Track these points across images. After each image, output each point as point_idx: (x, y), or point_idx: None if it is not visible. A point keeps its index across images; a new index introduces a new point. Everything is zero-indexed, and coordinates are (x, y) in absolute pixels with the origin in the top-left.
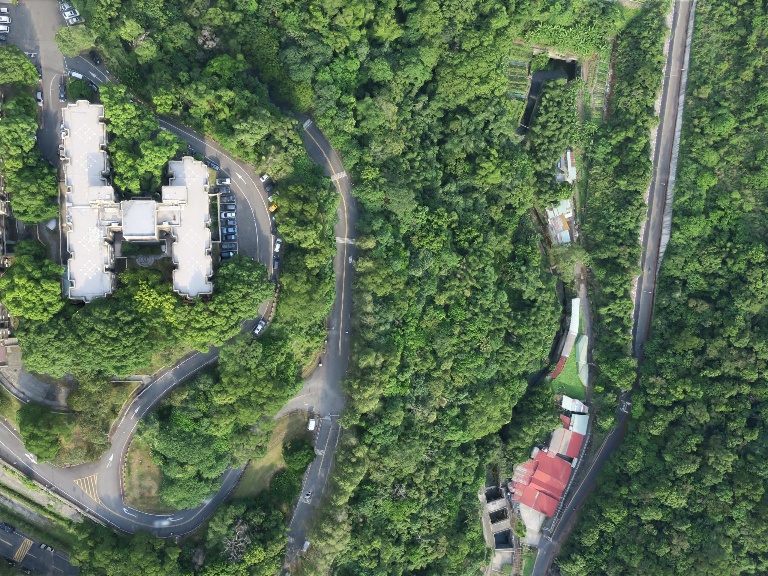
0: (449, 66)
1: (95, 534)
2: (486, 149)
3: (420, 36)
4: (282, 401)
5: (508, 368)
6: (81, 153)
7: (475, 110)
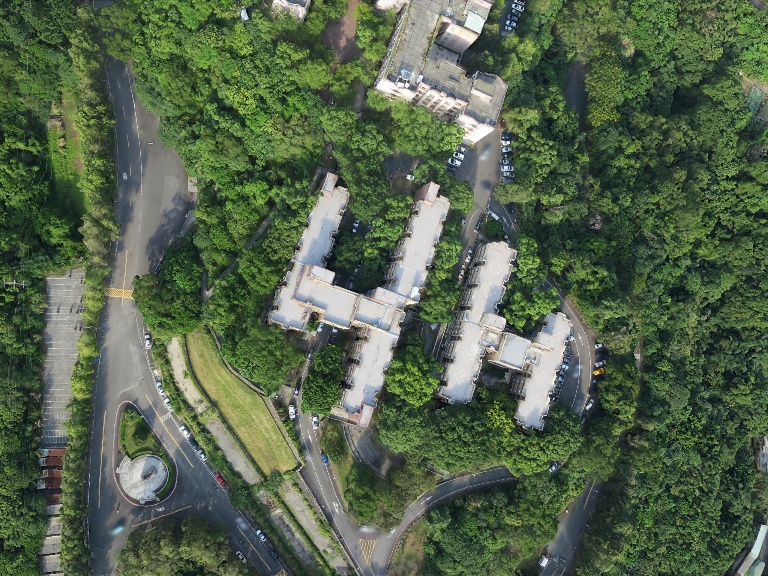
0: (740, 295)
1: None
2: (746, 373)
3: (724, 262)
4: (552, 539)
5: (700, 569)
6: (488, 282)
7: (746, 337)
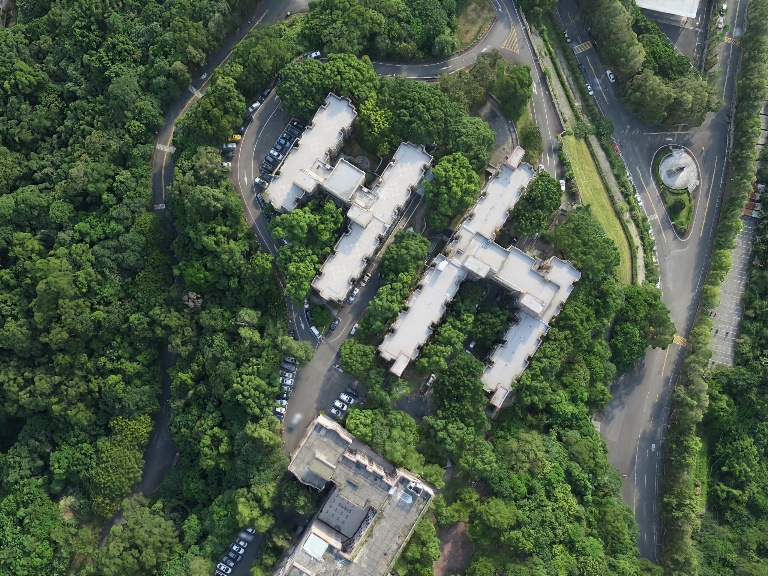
0: None
1: (530, 7)
2: (12, 93)
3: (0, 228)
4: None
5: None
6: (352, 259)
7: None
